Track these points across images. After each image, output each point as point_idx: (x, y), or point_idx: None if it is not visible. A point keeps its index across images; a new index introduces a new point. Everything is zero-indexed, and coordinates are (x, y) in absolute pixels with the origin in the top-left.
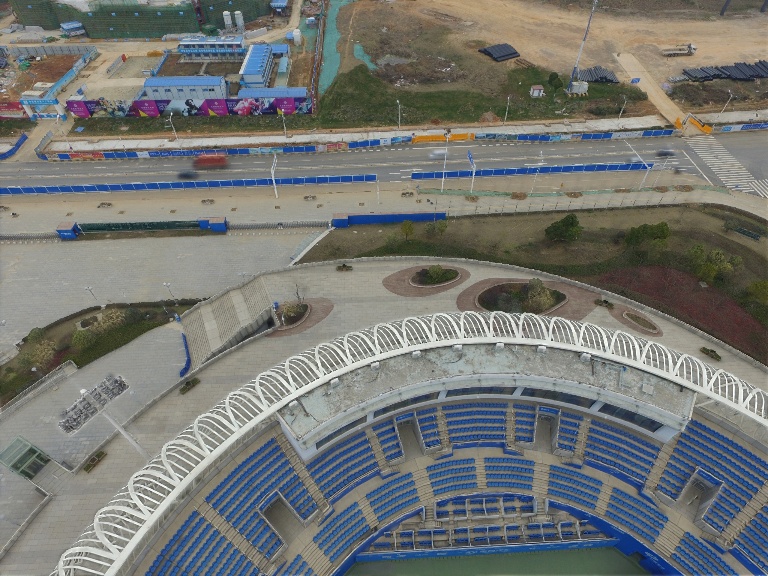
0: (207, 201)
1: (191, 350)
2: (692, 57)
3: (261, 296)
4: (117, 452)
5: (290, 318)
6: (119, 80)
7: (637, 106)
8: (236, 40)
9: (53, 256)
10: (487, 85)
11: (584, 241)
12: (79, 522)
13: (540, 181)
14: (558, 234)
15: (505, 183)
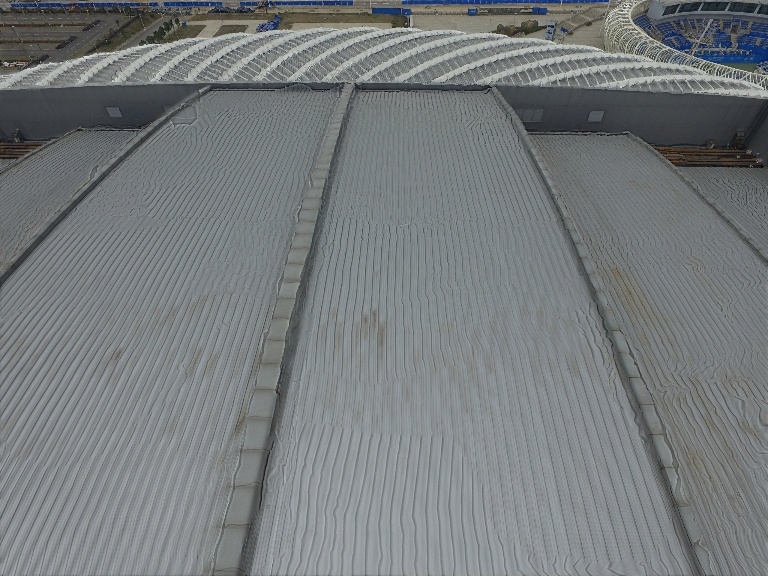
0: (527, 6)
1: None
2: None
3: None
4: (576, 33)
5: None
6: None
7: None
8: None
9: None
10: None
11: None
12: None
13: None
14: None
15: None
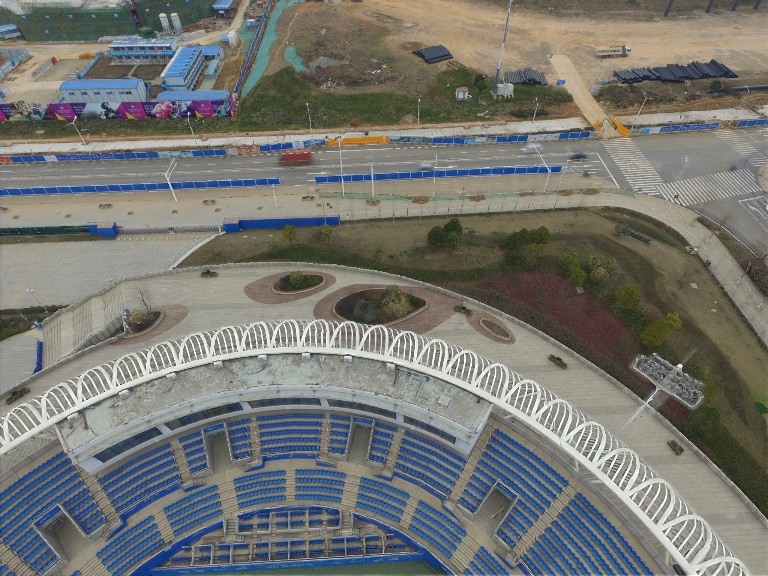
0: (104, 205)
1: (44, 358)
2: (627, 58)
3: (118, 303)
4: None
5: (137, 326)
6: (45, 83)
7: (561, 108)
8: (166, 42)
9: None
10: (415, 87)
11: (471, 246)
12: None
13: (446, 184)
14: (438, 239)
15: (410, 186)
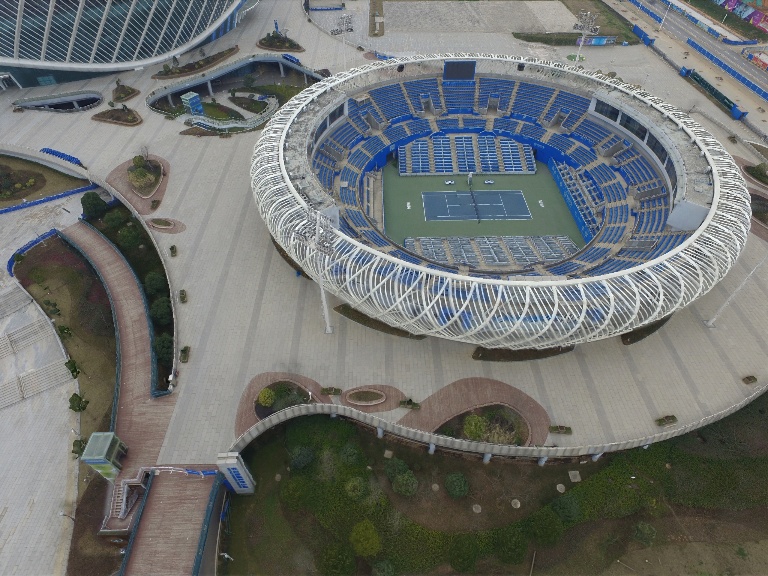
0: (761, 109)
1: None
2: None
3: None
4: None
5: None
6: None
7: None
8: None
9: (665, 74)
10: None
11: None
12: None
13: None
14: None
15: None
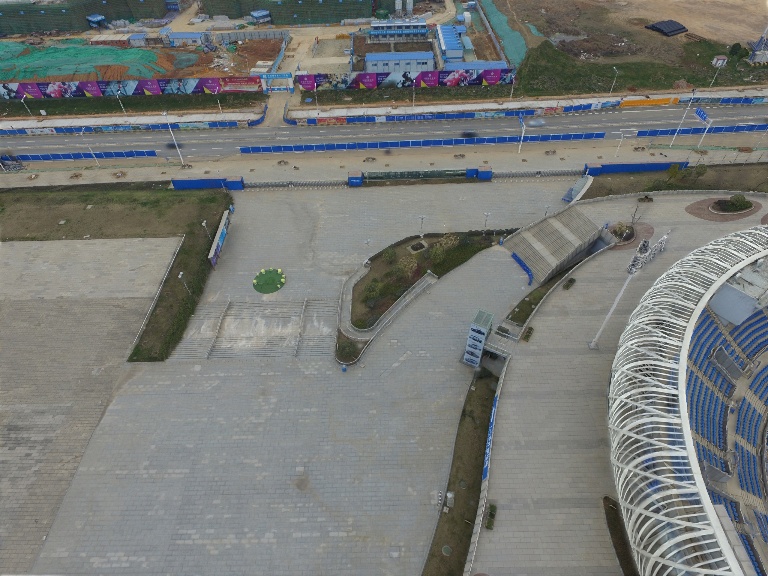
0: (459, 155)
1: None
2: None
3: (583, 221)
4: (540, 328)
5: (626, 235)
6: (322, 59)
7: None
8: (421, 22)
9: (350, 199)
10: (666, 57)
11: None
12: (543, 374)
13: (758, 137)
14: None
15: (725, 139)
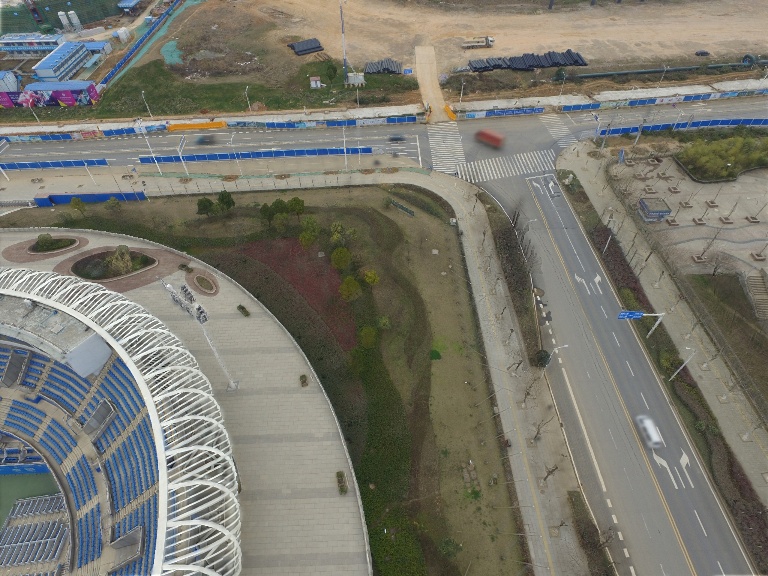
0: None
1: None
2: (490, 49)
3: None
4: None
5: None
6: None
7: (403, 95)
8: (53, 38)
9: None
10: (276, 77)
11: (247, 217)
12: None
13: (261, 164)
14: (203, 209)
15: (227, 166)
